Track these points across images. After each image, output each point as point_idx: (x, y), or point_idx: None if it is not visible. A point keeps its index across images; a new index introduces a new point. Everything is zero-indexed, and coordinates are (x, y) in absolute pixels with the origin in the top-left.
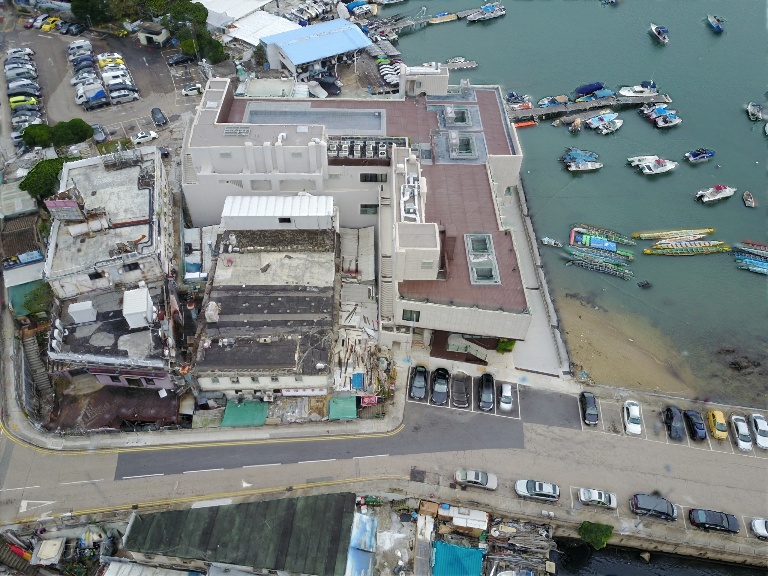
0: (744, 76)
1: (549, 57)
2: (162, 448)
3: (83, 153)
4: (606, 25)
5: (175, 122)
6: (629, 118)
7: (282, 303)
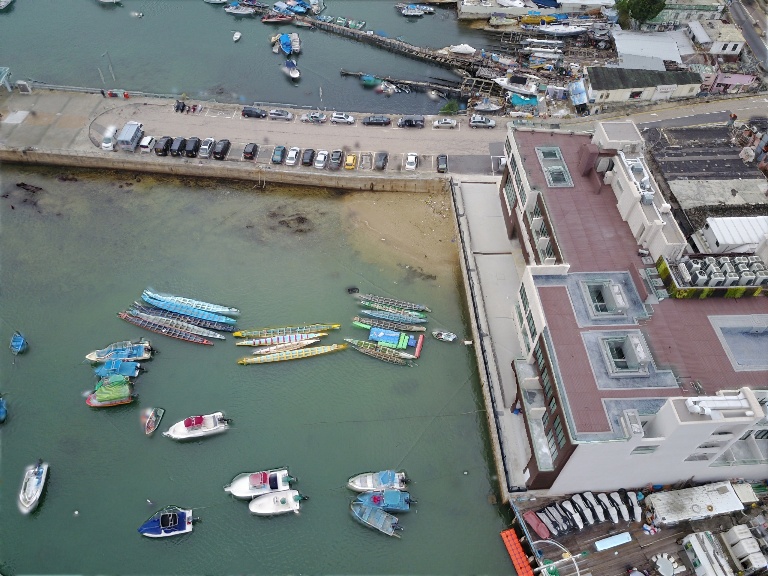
0: None
1: None
2: (716, 123)
3: None
4: None
5: None
6: None
7: (700, 167)
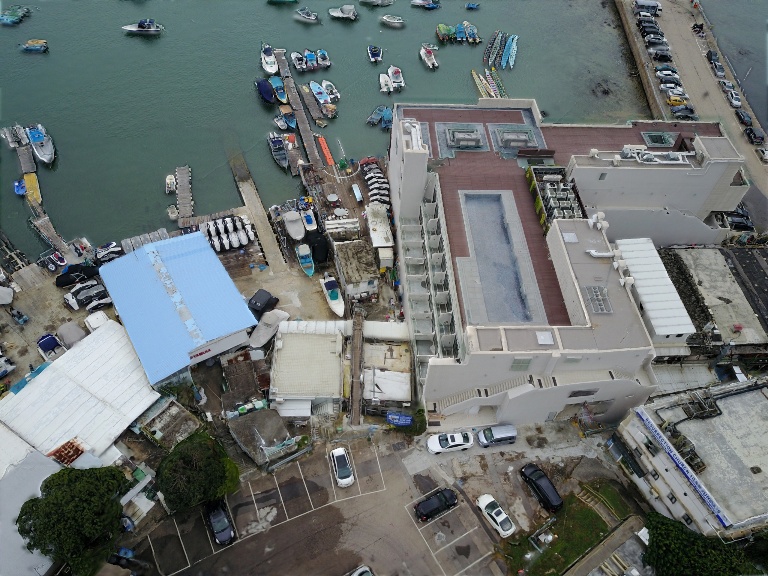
0: (237, 6)
1: (169, 111)
2: None
3: (619, 569)
4: (96, 60)
5: (438, 478)
6: (311, 79)
7: (760, 283)
